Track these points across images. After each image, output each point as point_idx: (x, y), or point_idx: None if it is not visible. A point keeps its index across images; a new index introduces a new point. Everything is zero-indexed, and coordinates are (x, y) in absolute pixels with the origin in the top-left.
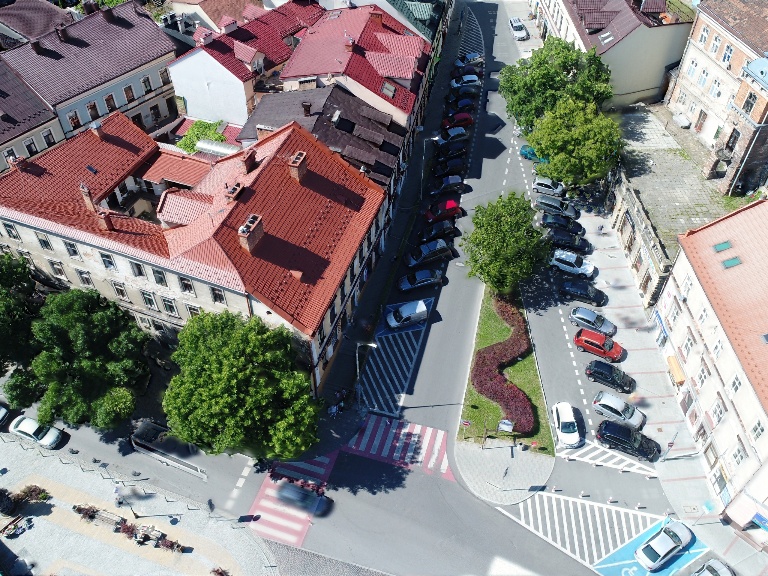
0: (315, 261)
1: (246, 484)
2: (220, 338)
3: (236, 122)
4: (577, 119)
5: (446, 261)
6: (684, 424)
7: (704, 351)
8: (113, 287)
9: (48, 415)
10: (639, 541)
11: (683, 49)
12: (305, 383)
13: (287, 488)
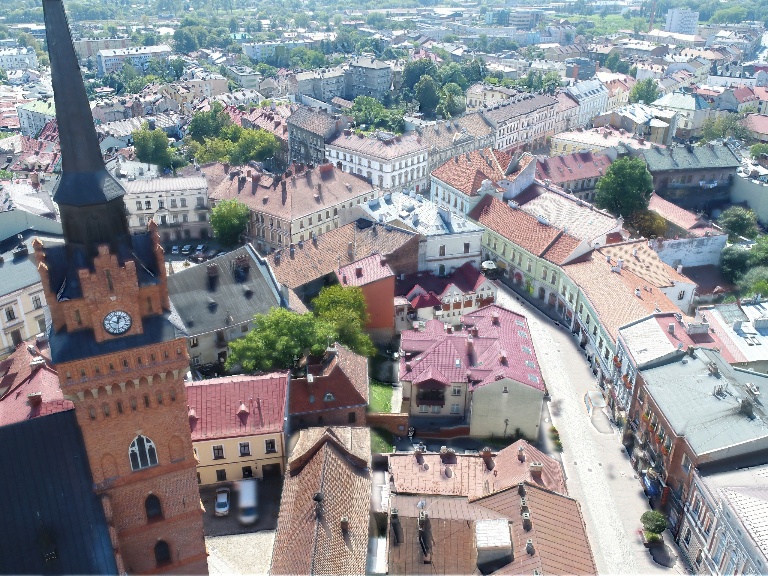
0: None
1: None
2: None
3: None
4: None
5: None
6: None
7: None
8: None
9: None
10: None
11: None
12: None
13: None
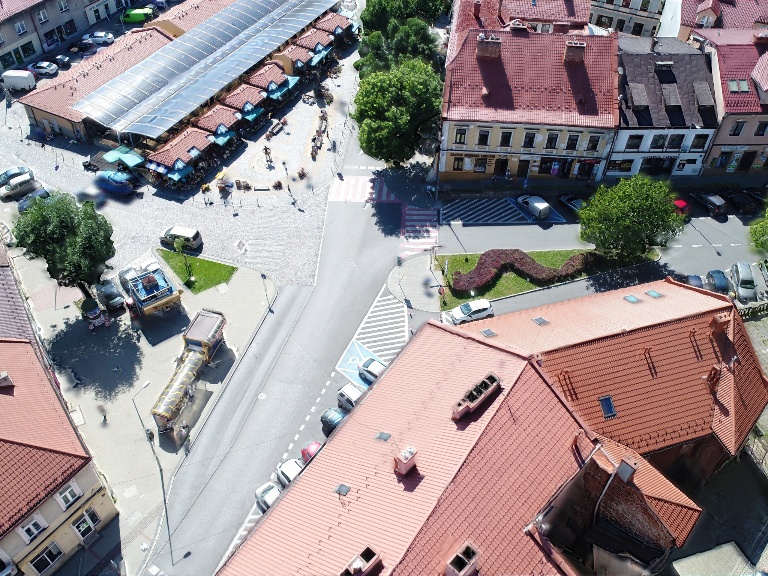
0: (507, 100)
1: (363, 170)
2: None
3: None
4: None
5: None
6: None
7: None
8: None
9: (357, 63)
10: None
11: None
12: None
13: (366, 186)
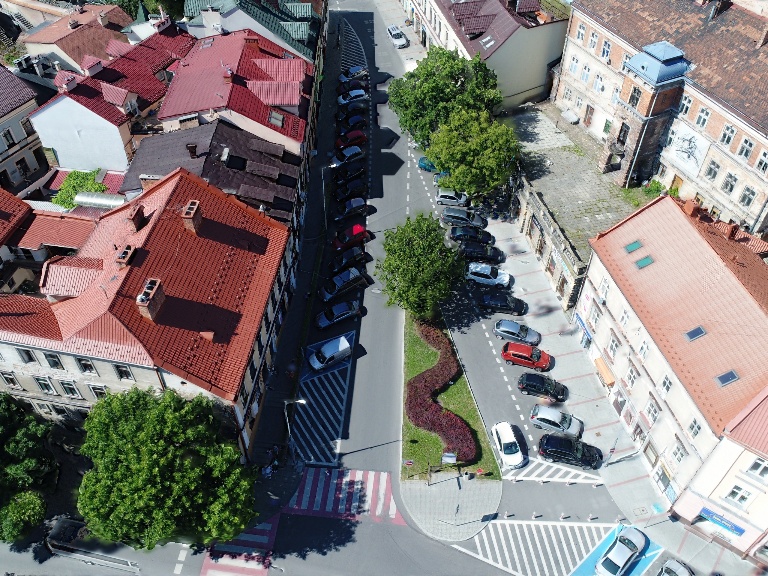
0: (225, 317)
1: (184, 570)
2: (133, 421)
3: (116, 169)
4: (472, 130)
5: (361, 290)
6: (620, 424)
7: (630, 352)
8: (1, 377)
9: None
10: (597, 554)
11: (562, 46)
12: (234, 456)
13: (230, 566)
